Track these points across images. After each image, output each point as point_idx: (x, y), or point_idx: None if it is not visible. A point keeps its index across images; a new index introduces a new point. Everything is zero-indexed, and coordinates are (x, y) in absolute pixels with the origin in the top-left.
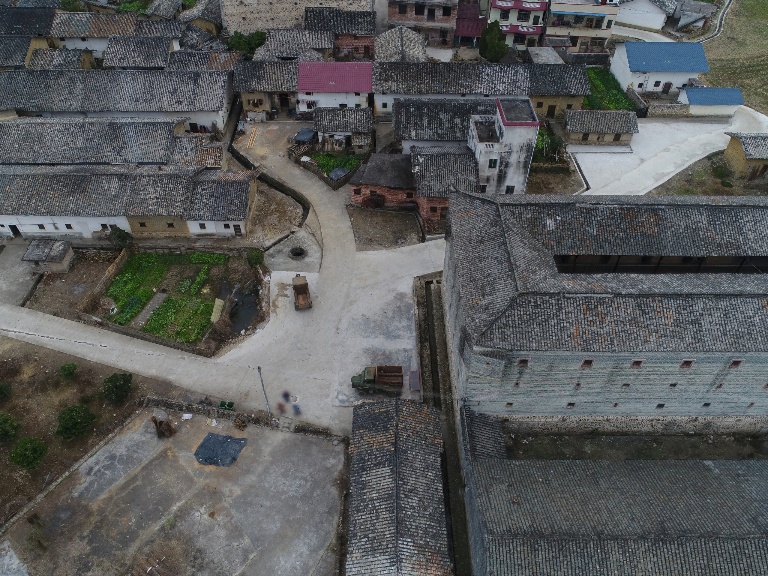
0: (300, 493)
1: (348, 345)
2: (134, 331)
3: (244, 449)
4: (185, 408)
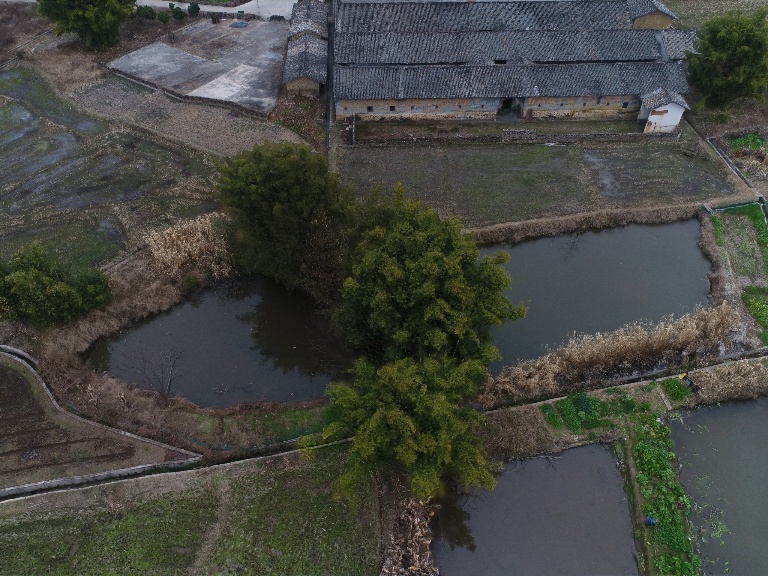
0: (273, 32)
1: (293, 2)
2: (197, 0)
3: (249, 25)
4: (223, 16)
